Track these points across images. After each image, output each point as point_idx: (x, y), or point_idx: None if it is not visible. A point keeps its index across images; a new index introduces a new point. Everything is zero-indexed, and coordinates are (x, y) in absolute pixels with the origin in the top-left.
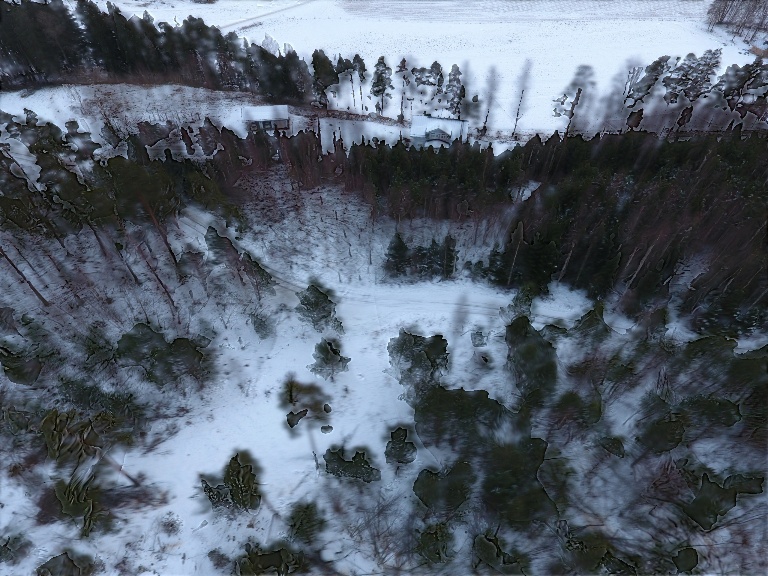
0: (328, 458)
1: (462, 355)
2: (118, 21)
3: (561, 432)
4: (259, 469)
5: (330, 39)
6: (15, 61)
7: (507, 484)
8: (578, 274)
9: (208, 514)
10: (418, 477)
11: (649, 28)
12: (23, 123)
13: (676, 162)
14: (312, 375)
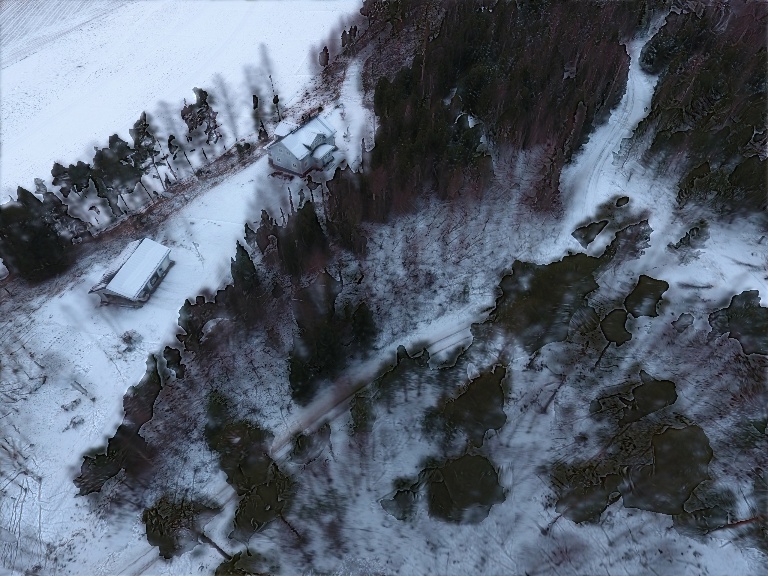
0: None
1: (645, 195)
2: None
3: None
4: None
5: None
6: None
7: None
8: None
9: None
10: None
11: (166, 0)
12: None
13: None
14: (678, 273)
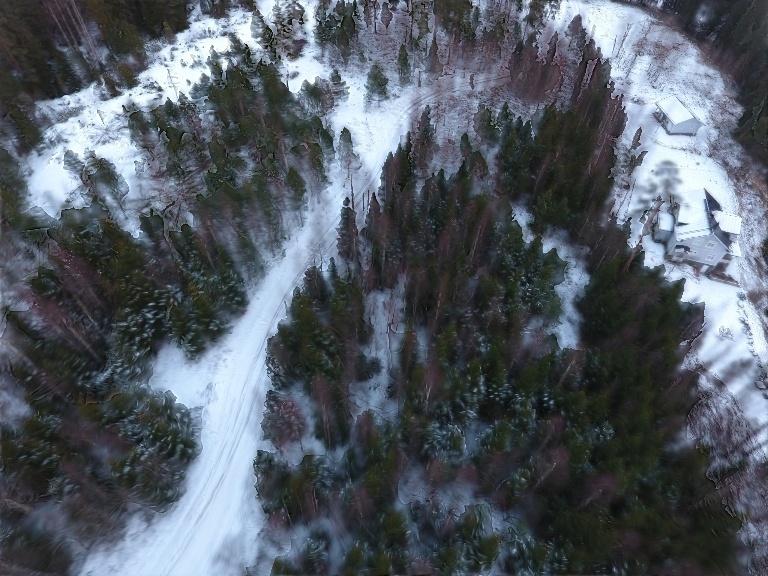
0: None
1: (337, 151)
2: (753, 4)
3: None
4: (294, 80)
5: None
6: None
7: None
8: None
9: None
10: None
11: None
12: (614, 28)
13: (617, 400)
14: None
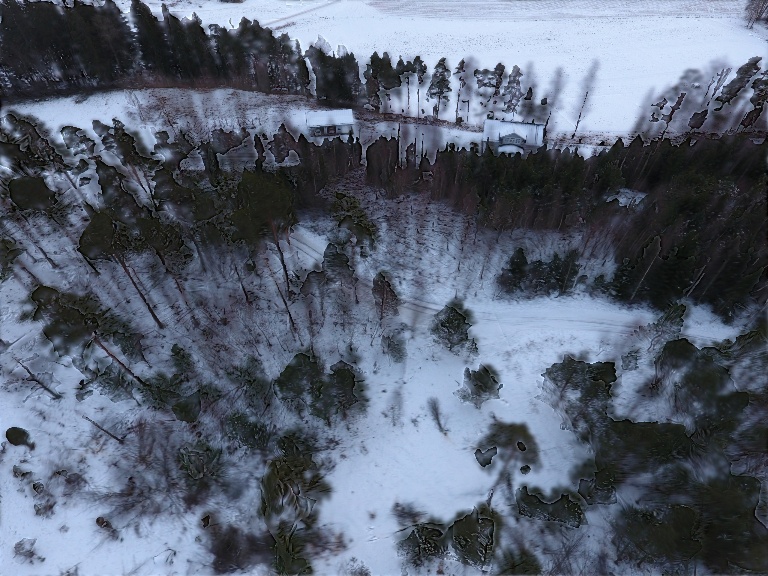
0: (528, 501)
1: None
2: (173, 24)
3: (738, 463)
4: (430, 507)
5: (366, 39)
6: (67, 66)
7: (739, 531)
8: (705, 288)
9: (393, 559)
10: (632, 522)
11: (688, 25)
12: (82, 130)
13: None
14: (455, 401)
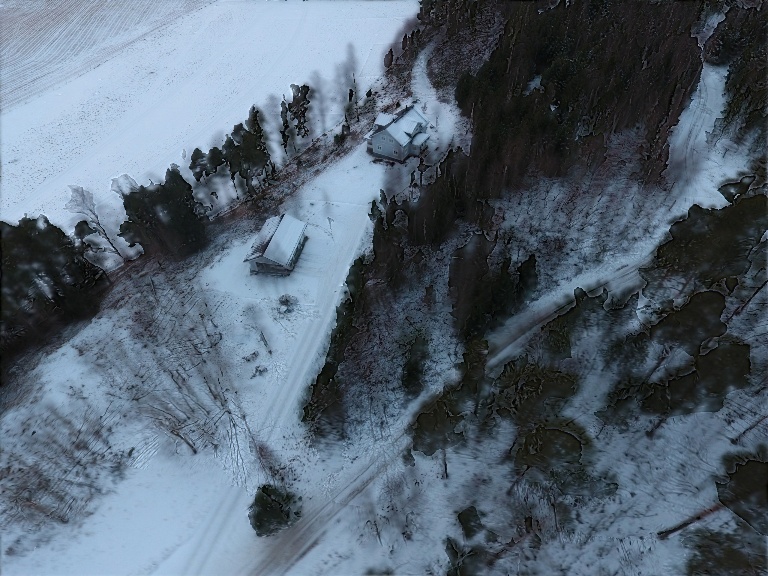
0: None
1: (743, 169)
2: None
3: None
4: None
5: None
6: None
7: None
8: None
9: None
10: None
11: (220, 11)
12: None
13: None
14: None
